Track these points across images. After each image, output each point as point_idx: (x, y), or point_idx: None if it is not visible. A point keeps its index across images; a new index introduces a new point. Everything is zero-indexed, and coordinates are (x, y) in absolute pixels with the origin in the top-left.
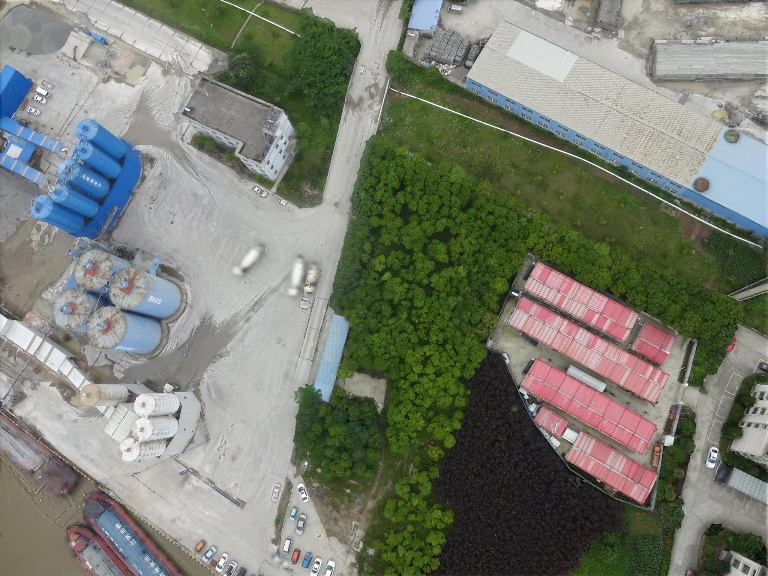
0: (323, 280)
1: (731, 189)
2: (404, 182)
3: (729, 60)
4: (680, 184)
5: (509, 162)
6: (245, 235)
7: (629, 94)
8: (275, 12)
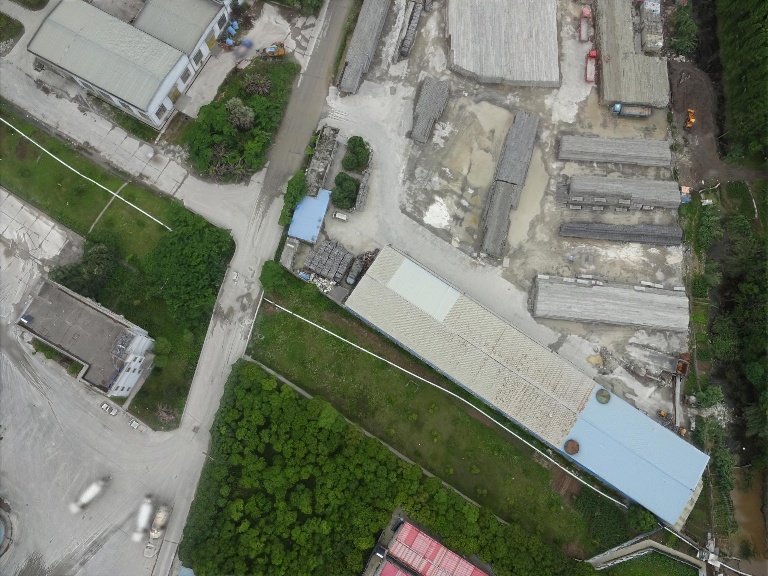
0: (174, 519)
1: (600, 454)
2: (270, 419)
3: (606, 306)
4: (552, 444)
5: (385, 396)
6: (88, 459)
7: (508, 341)
8: (143, 196)
